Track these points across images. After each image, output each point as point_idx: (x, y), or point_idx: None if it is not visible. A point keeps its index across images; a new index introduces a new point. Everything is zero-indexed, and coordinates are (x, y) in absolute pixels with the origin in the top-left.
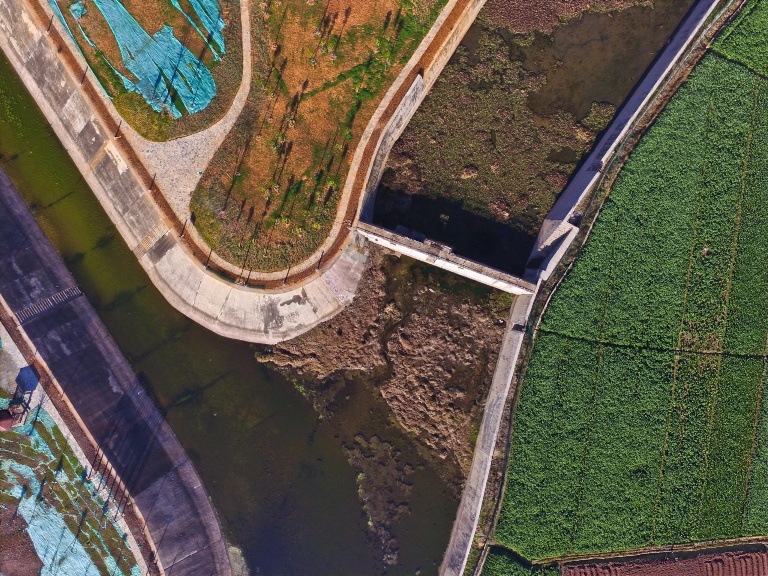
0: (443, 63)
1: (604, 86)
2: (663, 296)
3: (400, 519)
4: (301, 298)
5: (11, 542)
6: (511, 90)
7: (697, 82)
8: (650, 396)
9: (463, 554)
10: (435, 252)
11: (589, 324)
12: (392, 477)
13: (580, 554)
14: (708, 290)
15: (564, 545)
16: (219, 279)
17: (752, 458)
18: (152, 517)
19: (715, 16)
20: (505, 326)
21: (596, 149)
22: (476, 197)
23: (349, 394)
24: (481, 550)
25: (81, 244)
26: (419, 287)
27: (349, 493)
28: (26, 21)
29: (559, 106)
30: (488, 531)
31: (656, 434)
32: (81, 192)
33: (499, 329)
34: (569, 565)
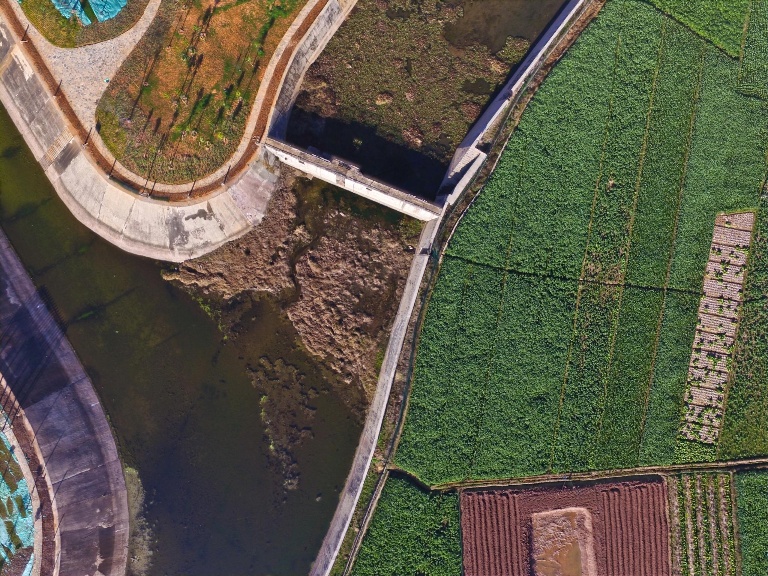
0: None
1: (519, 21)
2: (567, 225)
3: (303, 444)
4: (207, 213)
5: None
6: (428, 20)
7: (606, 18)
8: (552, 324)
9: (361, 476)
10: (343, 172)
11: (494, 250)
12: (296, 401)
13: (479, 480)
14: (612, 222)
15: (463, 470)
16: (122, 189)
17: (650, 389)
18: (43, 430)
19: None
20: (414, 252)
21: (509, 81)
22: (390, 123)
23: (255, 315)
24: (380, 474)
25: None
26: (330, 210)
27: (252, 416)
28: None
29: (475, 38)
30: (388, 455)
31: (557, 362)
32: None
33: (408, 255)
34: (468, 491)
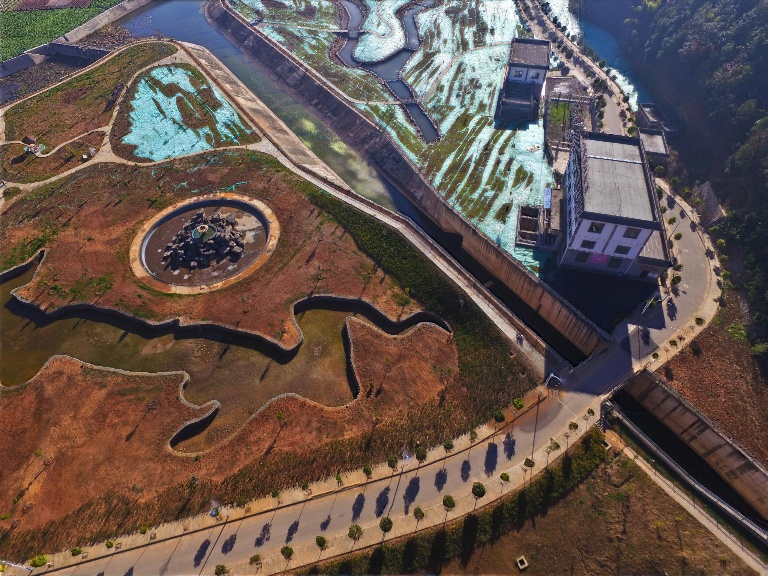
0: None
1: None
2: None
3: None
4: None
5: (270, 4)
6: None
7: None
8: None
9: None
10: None
11: None
12: None
13: None
14: None
15: None
16: None
17: (1, 22)
18: None
19: None
20: None
21: None
22: None
23: None
24: None
25: None
26: None
27: None
28: (231, 88)
29: (5, 87)
30: None
31: None
32: None
33: None
34: None
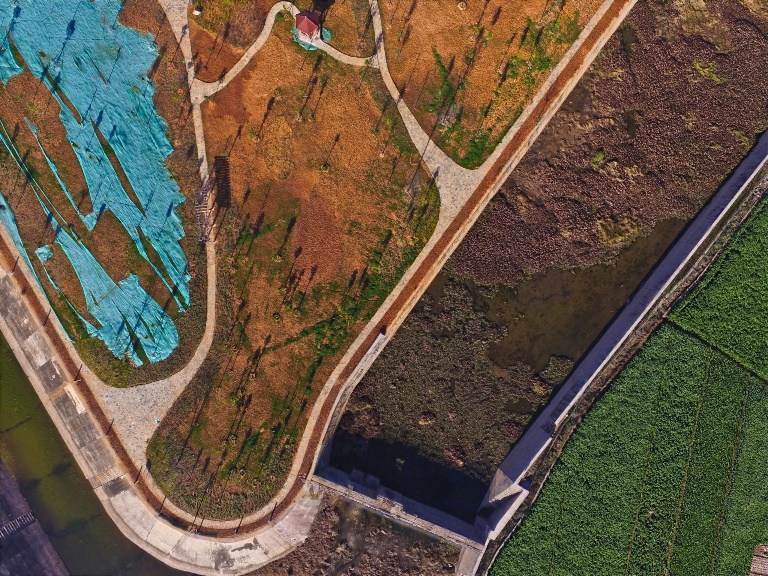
0: (407, 312)
1: (563, 340)
2: (607, 558)
3: None
4: (253, 545)
5: None
6: (472, 340)
7: (651, 352)
8: None
9: None
10: (387, 508)
11: None
12: None
13: None
14: (651, 553)
15: None
16: (171, 526)
17: None
18: None
19: (673, 287)
20: (453, 571)
21: (552, 403)
22: (432, 443)
23: None
24: None
25: (37, 470)
26: (371, 528)
27: None
28: None
29: (518, 358)
30: None
31: None
32: (40, 418)
33: (447, 574)
34: None
